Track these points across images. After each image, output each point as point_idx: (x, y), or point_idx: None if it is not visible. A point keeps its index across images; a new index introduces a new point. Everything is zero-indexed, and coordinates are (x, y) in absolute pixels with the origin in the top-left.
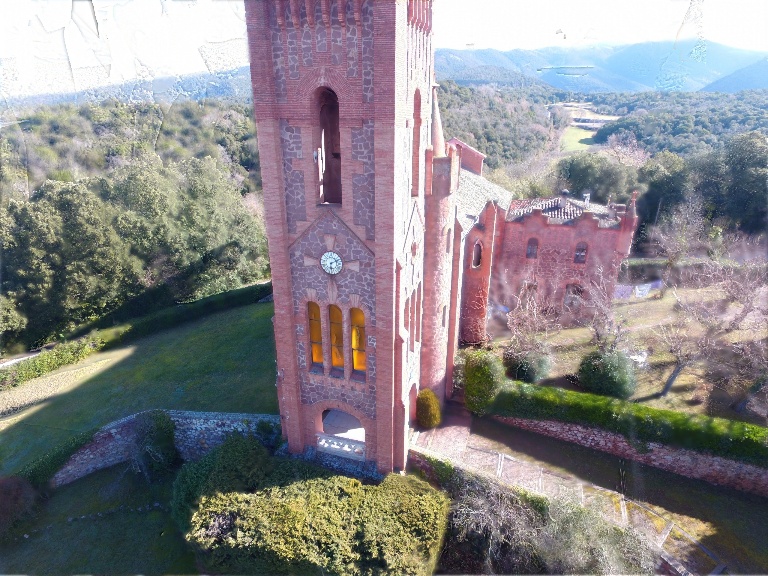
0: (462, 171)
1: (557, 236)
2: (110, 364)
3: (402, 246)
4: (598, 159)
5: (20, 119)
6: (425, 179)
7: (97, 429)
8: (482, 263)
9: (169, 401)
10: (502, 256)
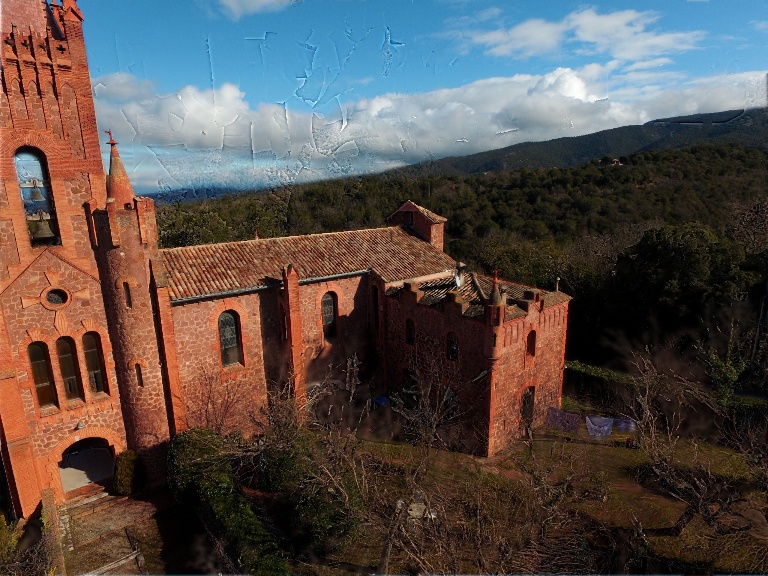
0: (400, 236)
1: (429, 320)
2: None
3: (1, 288)
4: (690, 233)
5: (208, 190)
6: (91, 230)
7: None
8: (287, 334)
9: None
10: (387, 336)
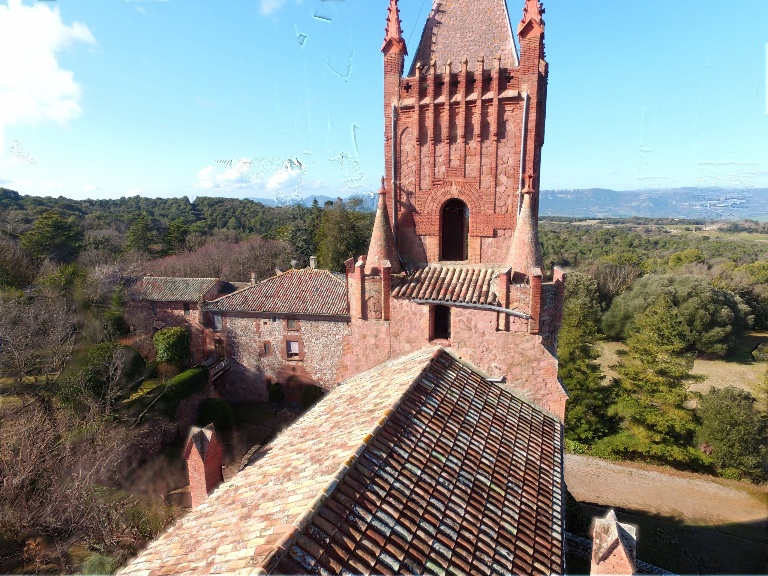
0: None
1: None
2: None
3: None
4: None
5: None
6: None
7: None
8: None
9: None
10: None
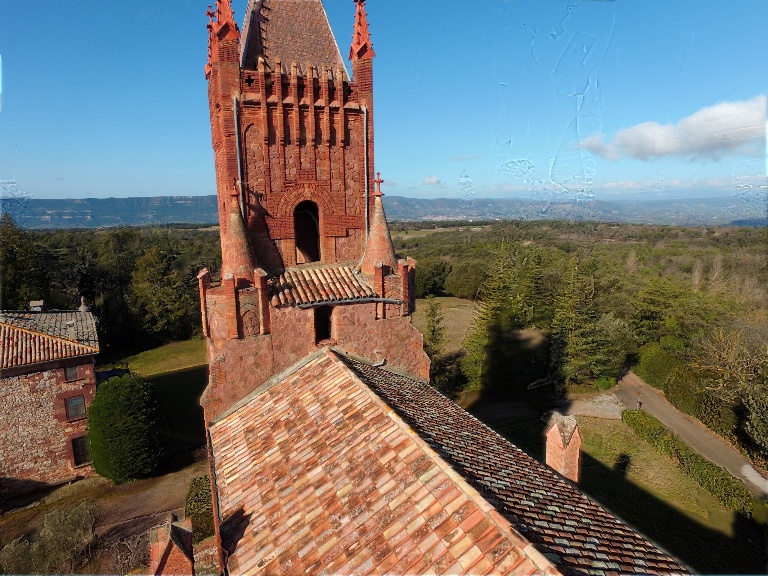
0: None
1: None
2: (688, 514)
3: None
4: None
5: None
6: None
7: None
8: None
9: None
10: None
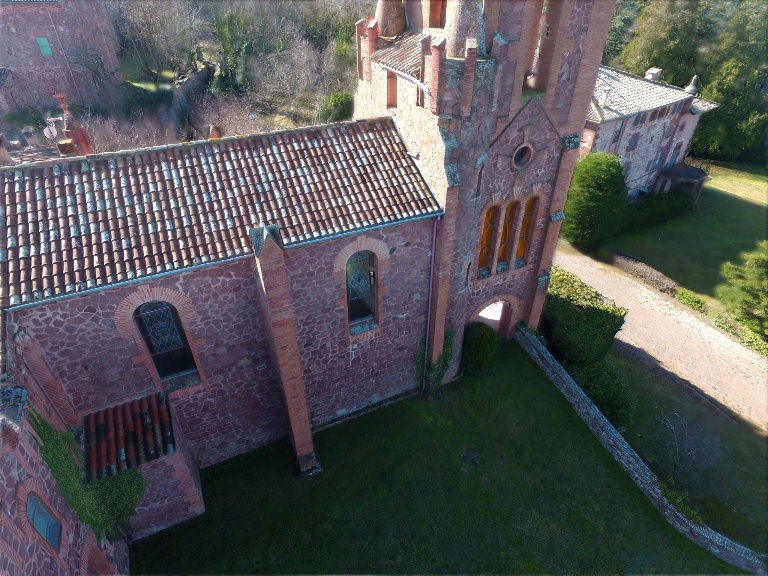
0: None
1: None
2: None
3: None
4: None
5: None
6: None
7: (767, 562)
8: None
9: (652, 566)
10: None
